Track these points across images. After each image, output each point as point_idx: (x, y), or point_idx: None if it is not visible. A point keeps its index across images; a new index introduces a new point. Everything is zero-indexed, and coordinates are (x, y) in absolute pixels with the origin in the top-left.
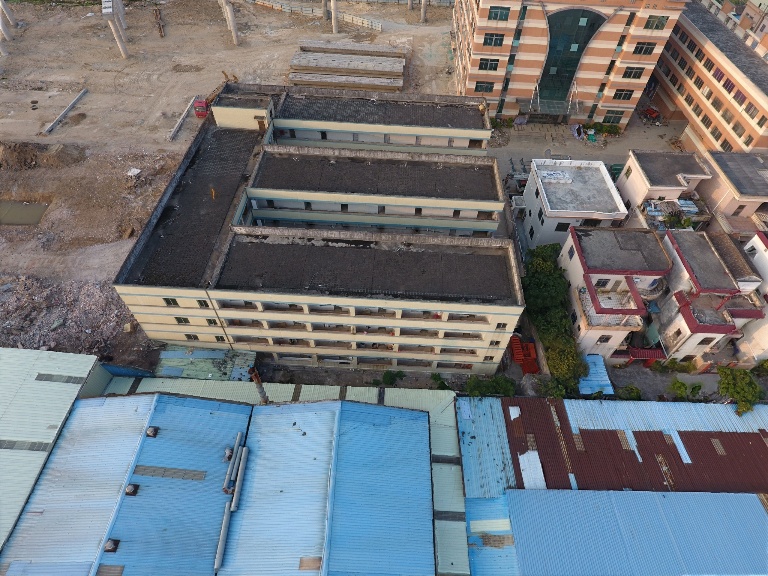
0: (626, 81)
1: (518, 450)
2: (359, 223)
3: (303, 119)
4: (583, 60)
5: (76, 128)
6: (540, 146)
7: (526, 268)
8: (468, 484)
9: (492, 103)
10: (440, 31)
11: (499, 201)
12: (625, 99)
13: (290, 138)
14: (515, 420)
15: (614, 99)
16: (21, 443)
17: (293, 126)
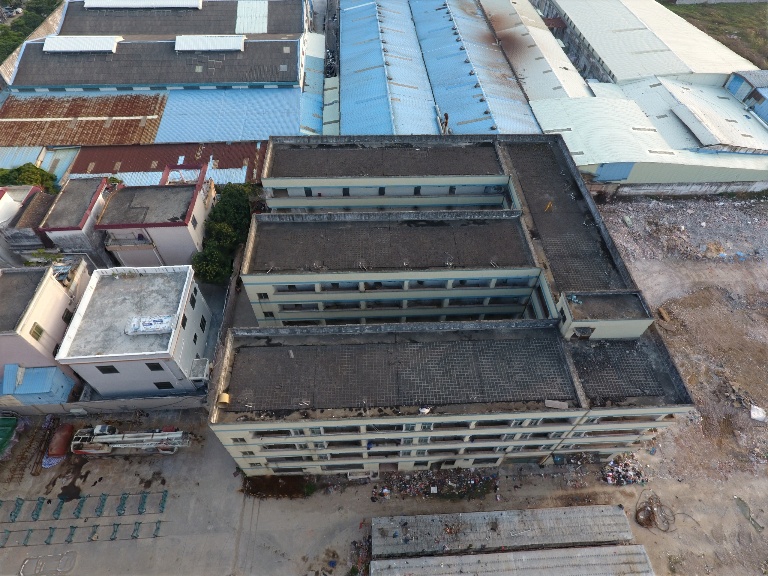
0: None
1: None
2: None
3: (515, 320)
4: None
5: None
6: None
7: None
8: None
9: None
10: None
11: None
12: None
13: None
14: None
15: None
16: (560, 131)
17: (528, 327)
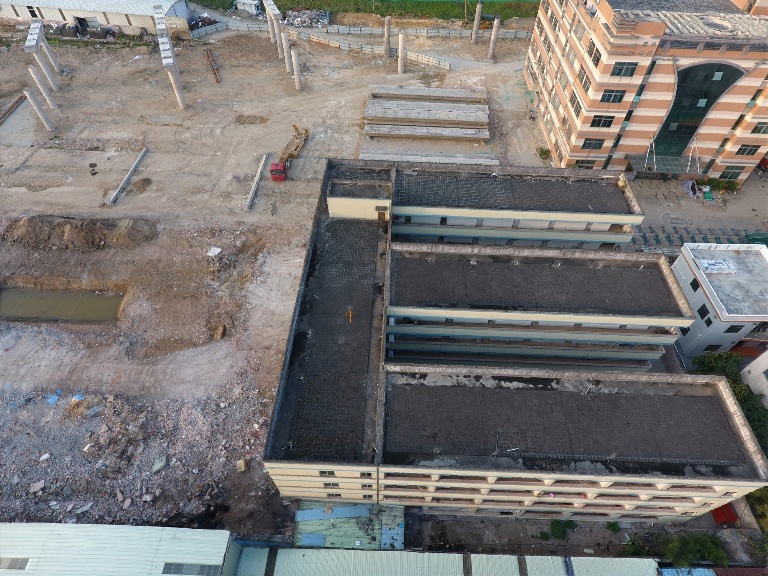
0: (754, 136)
1: None
2: (510, 337)
3: (427, 206)
4: (709, 115)
5: (142, 197)
6: (653, 207)
7: None
8: None
9: (599, 160)
10: (511, 68)
11: (689, 318)
12: (749, 154)
13: (407, 224)
14: None
15: (736, 155)
16: None
17: (414, 213)
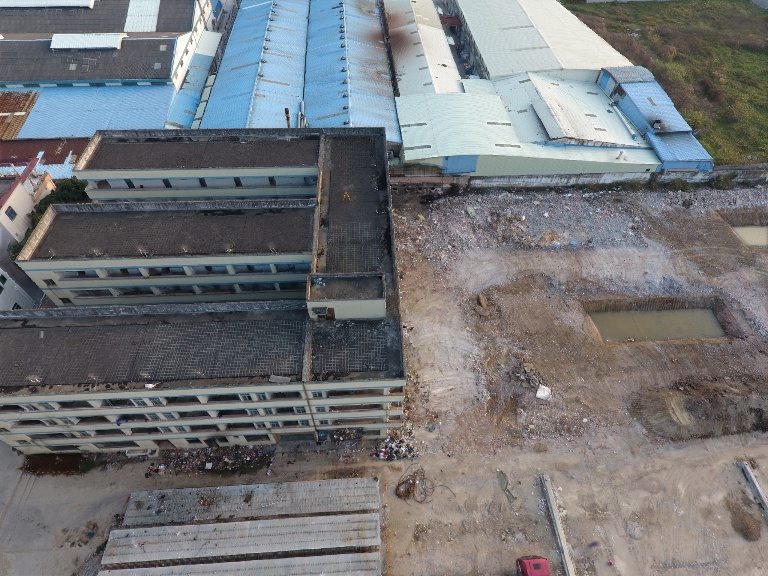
0: None
1: None
2: None
3: (265, 302)
4: None
5: (717, 491)
6: None
7: None
8: None
9: None
10: None
11: (57, 204)
12: None
13: None
14: None
15: None
16: (415, 125)
17: (283, 308)
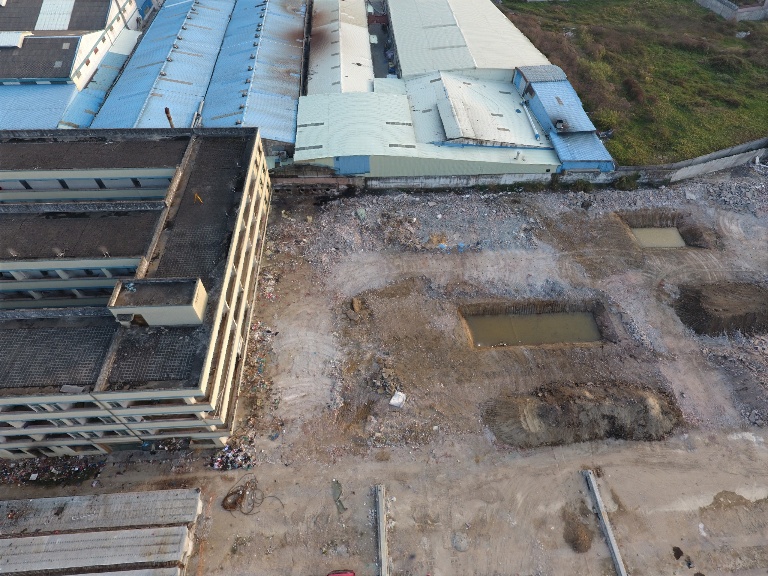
0: None
1: None
2: None
3: (76, 308)
4: None
5: (556, 500)
6: None
7: None
8: None
9: None
10: None
11: None
12: None
13: None
14: None
15: None
16: (312, 125)
17: (99, 315)
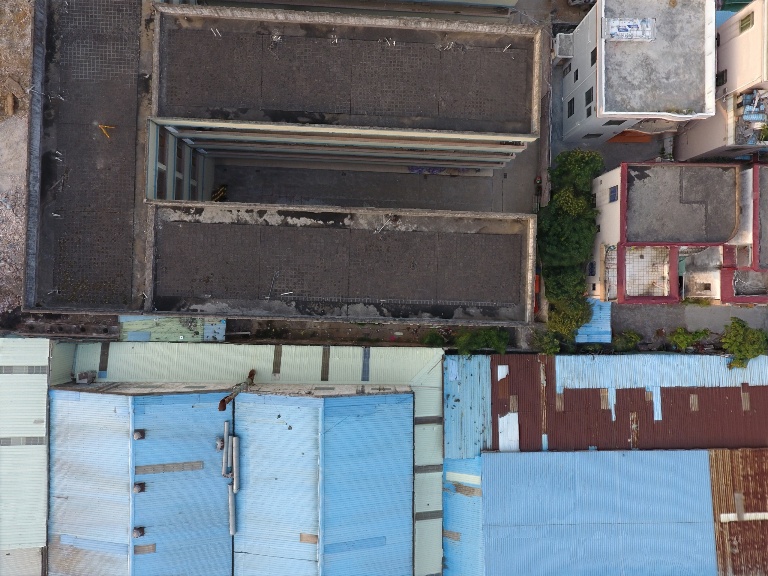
0: None
1: (499, 412)
2: (328, 143)
3: None
4: None
5: None
6: None
7: (551, 177)
8: (448, 447)
9: None
10: None
11: (530, 135)
12: None
13: None
14: (502, 381)
15: None
16: (16, 439)
17: None
